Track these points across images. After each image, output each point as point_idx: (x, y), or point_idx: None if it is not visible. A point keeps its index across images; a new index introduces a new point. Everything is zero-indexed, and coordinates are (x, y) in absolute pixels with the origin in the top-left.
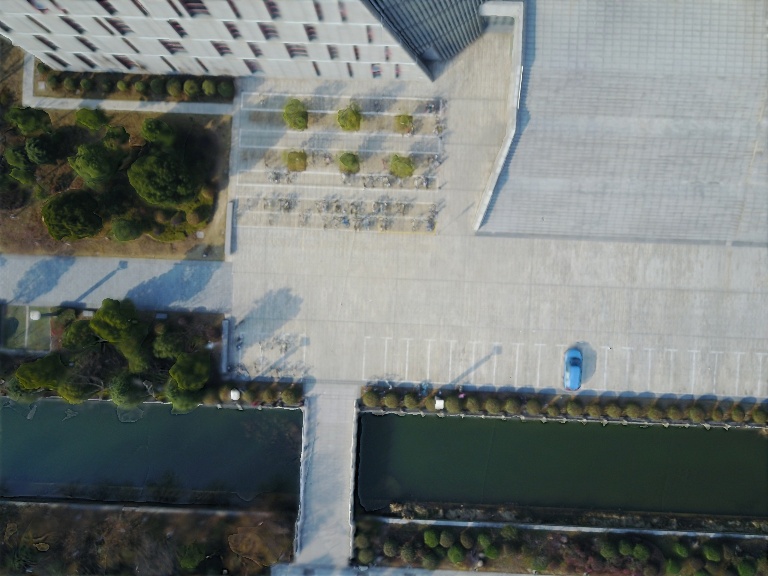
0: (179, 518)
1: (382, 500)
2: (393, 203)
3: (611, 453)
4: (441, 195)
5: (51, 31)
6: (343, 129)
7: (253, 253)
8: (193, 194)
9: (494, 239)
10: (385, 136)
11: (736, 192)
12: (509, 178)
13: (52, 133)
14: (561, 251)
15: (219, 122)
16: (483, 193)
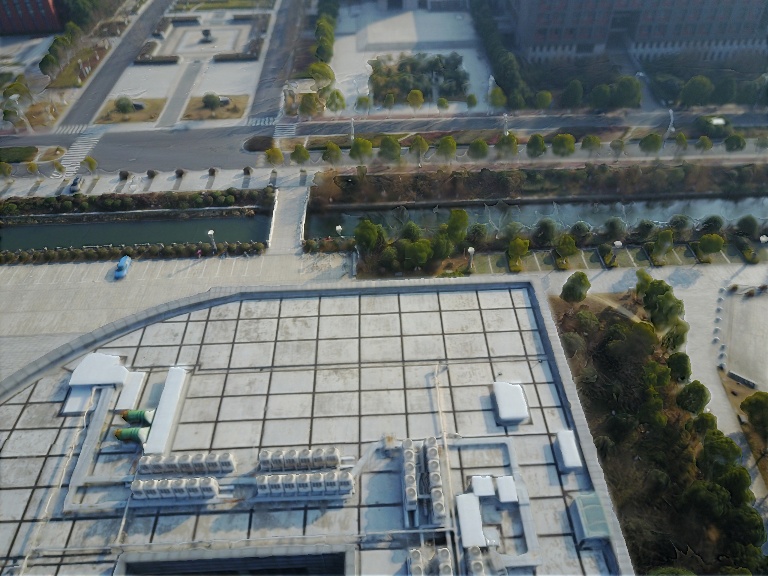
0: (380, 200)
1: (261, 222)
2: None
3: None
4: None
5: None
6: None
7: None
8: None
9: None
10: None
11: None
12: None
13: None
14: None
15: None
16: None
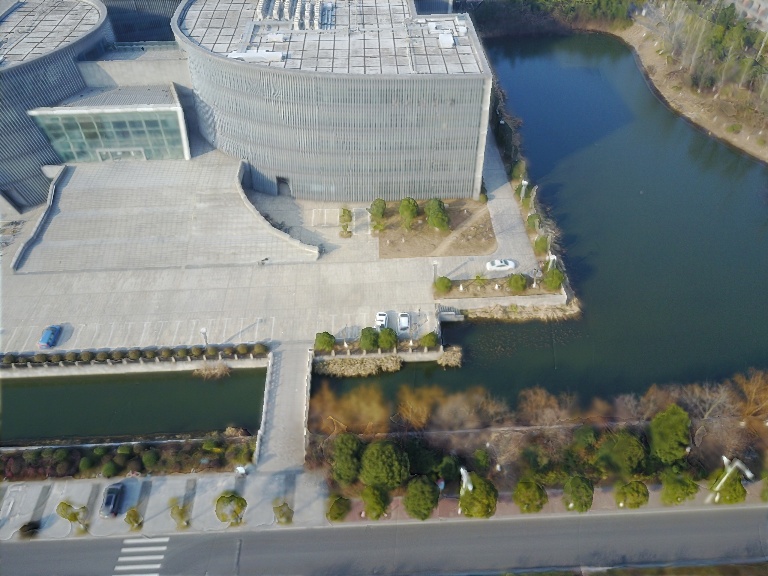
0: None
1: None
2: None
3: (75, 402)
4: (0, 259)
5: None
6: None
7: None
8: None
9: (26, 276)
10: None
11: (184, 239)
12: (42, 242)
13: None
14: (69, 278)
15: None
16: None
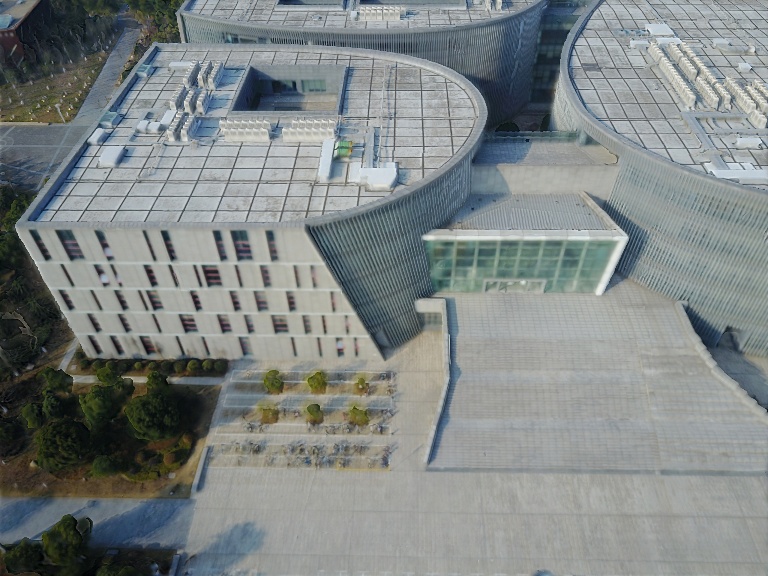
0: None
1: None
2: (351, 446)
3: None
4: (394, 439)
5: (103, 309)
6: (312, 392)
7: (218, 490)
8: (176, 432)
9: (443, 474)
10: (346, 397)
11: (646, 426)
12: (450, 419)
13: (69, 395)
14: (506, 483)
15: (210, 390)
16: (429, 432)
